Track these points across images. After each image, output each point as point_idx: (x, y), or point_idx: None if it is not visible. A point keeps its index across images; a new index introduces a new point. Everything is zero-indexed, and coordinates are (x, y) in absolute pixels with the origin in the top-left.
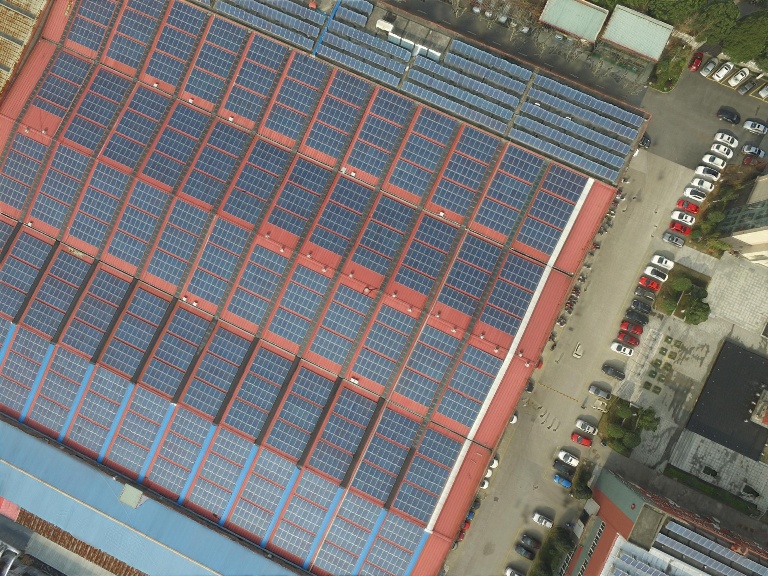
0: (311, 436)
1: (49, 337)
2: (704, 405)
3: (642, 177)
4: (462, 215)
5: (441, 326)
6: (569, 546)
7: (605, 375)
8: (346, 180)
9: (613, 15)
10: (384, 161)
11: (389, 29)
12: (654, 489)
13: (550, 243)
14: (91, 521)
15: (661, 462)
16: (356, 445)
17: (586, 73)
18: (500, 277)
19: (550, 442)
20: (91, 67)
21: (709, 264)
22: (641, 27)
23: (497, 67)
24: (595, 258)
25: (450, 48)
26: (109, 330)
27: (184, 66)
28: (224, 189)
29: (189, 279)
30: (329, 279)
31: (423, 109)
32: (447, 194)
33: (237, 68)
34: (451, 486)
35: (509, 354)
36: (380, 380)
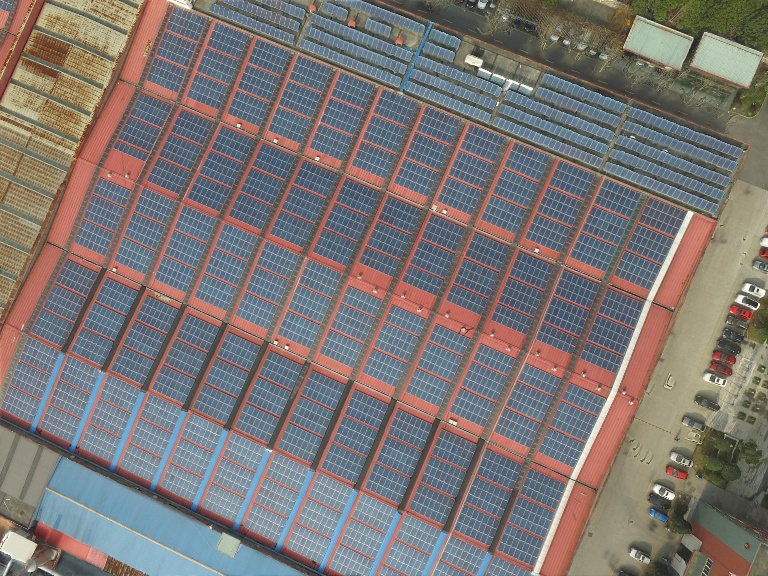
0: (411, 480)
1: (139, 385)
2: None
3: (729, 204)
4: (558, 251)
5: (541, 365)
6: None
7: (698, 406)
8: (437, 218)
9: (701, 43)
10: (476, 198)
11: (479, 64)
12: (752, 521)
13: (649, 278)
14: (185, 570)
15: (758, 493)
16: (457, 488)
17: (668, 100)
18: (599, 313)
19: (644, 475)
20: (172, 109)
21: None
22: (730, 54)
23: (590, 100)
24: None
25: (541, 82)
26: (200, 376)
27: (268, 106)
28: (313, 230)
29: (280, 322)
30: (424, 319)
31: (515, 144)
32: (542, 230)
33: (322, 107)
34: (556, 528)
35: (612, 392)
36: (479, 421)
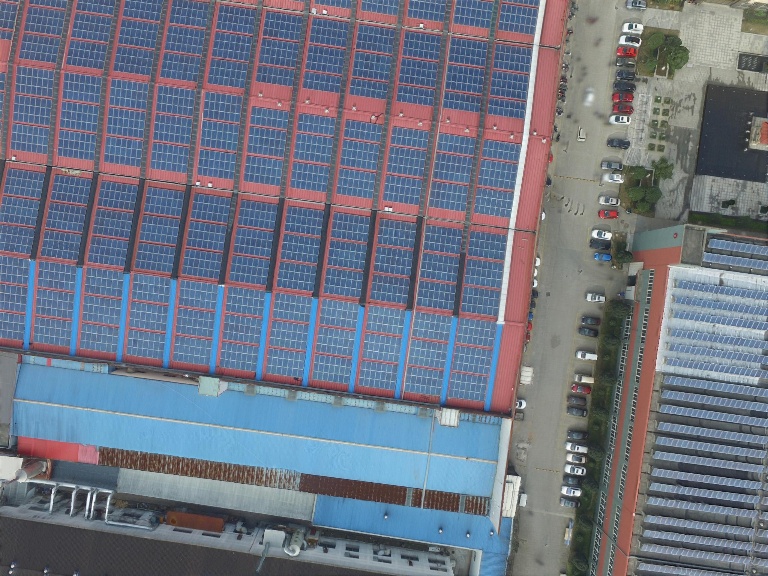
0: (364, 273)
1: (73, 262)
2: (706, 148)
3: None
4: (441, 21)
5: (454, 130)
6: (626, 307)
7: (612, 149)
8: (320, 20)
9: None
10: None
11: None
12: None
13: (530, 23)
14: (175, 430)
15: (683, 212)
16: (409, 267)
17: None
18: (494, 68)
19: (581, 226)
20: None
21: (674, 19)
22: None
23: None
24: (571, 44)
25: None
26: (132, 236)
27: None
28: (202, 63)
29: (196, 163)
30: (334, 119)
31: None
32: (421, 5)
33: None
34: (508, 276)
35: (524, 136)
36: (412, 200)
